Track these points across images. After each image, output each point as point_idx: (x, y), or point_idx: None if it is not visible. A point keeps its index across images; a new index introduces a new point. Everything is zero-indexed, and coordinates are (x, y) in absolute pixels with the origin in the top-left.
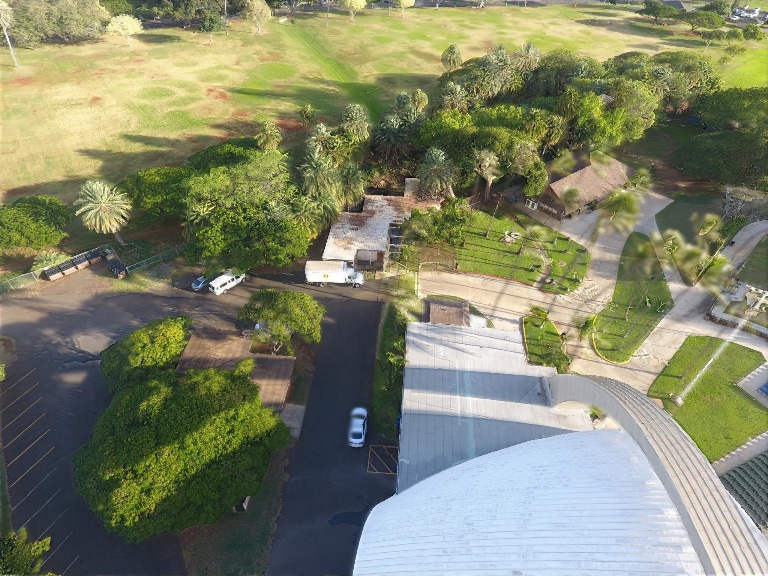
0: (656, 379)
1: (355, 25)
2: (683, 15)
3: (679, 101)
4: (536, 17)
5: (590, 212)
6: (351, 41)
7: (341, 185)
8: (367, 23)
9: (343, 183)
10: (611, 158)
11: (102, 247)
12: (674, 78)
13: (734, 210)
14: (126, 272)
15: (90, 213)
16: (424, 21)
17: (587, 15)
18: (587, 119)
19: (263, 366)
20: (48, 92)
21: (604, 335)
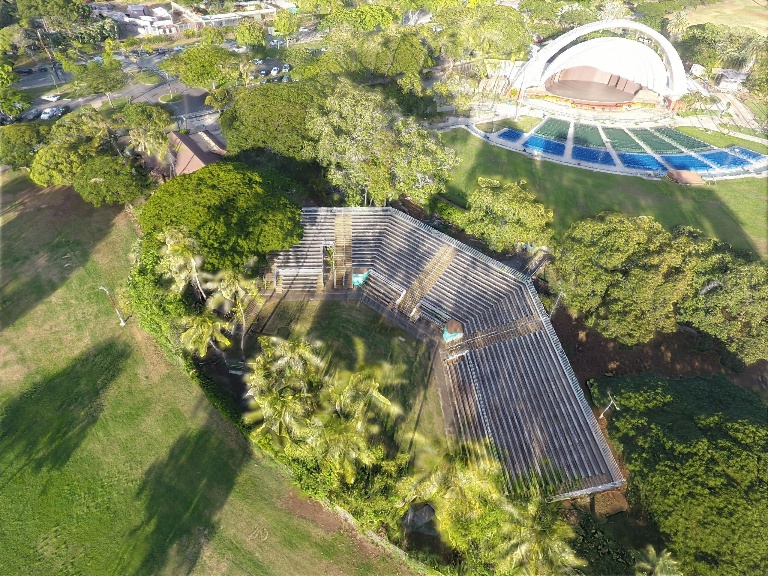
0: (718, 131)
1: None
2: None
3: None
4: None
5: None
6: None
7: (763, 60)
8: None
9: (765, 59)
10: None
11: None
12: None
13: None
14: None
15: (671, 21)
16: None
17: None
18: None
19: None
20: (759, 20)
21: None
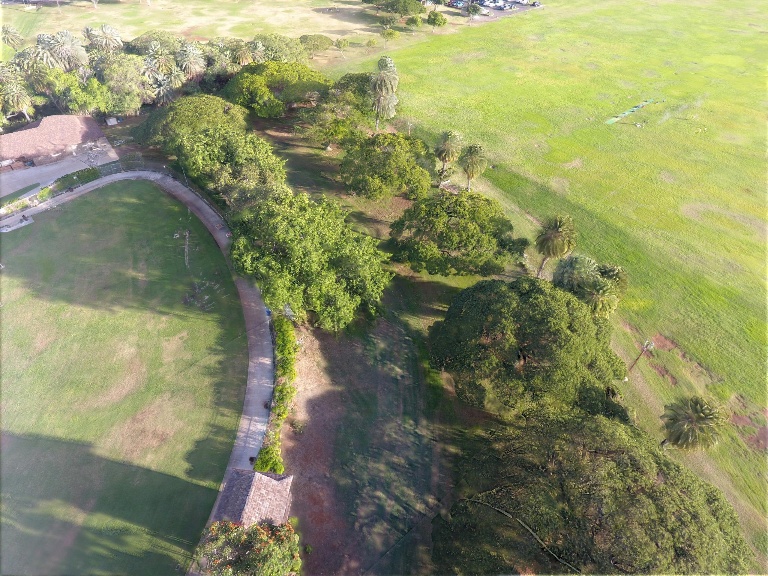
0: None
1: (91, 12)
2: (389, 3)
3: (209, 76)
4: (280, 5)
5: (28, 168)
6: (62, 26)
7: None
8: (106, 10)
9: None
10: (71, 122)
11: None
12: (214, 55)
13: (92, 162)
14: None
15: None
16: (164, 9)
17: (334, 4)
18: (62, 88)
19: None
20: None
21: None
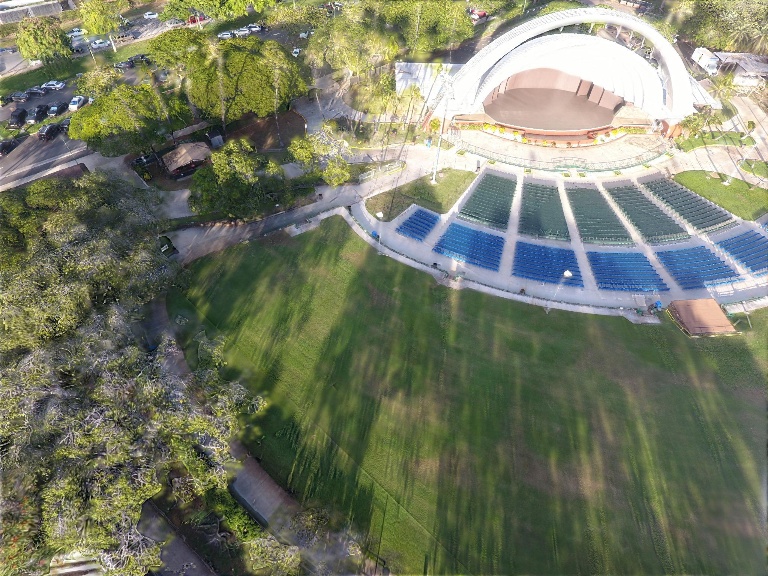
0: (739, 179)
1: None
2: None
3: None
4: None
5: None
6: None
7: None
8: None
9: None
10: None
11: (652, 4)
12: None
13: None
14: (643, 14)
15: None
16: None
17: None
18: None
19: (619, 42)
20: None
21: (764, 165)
